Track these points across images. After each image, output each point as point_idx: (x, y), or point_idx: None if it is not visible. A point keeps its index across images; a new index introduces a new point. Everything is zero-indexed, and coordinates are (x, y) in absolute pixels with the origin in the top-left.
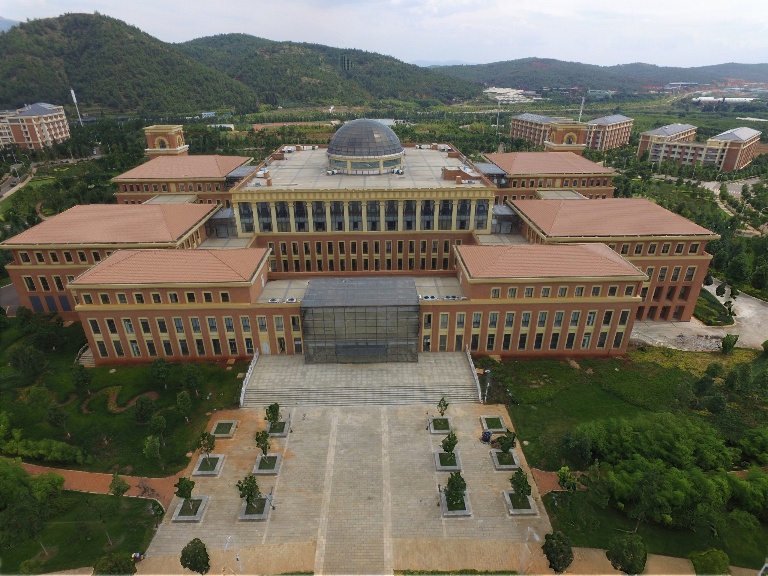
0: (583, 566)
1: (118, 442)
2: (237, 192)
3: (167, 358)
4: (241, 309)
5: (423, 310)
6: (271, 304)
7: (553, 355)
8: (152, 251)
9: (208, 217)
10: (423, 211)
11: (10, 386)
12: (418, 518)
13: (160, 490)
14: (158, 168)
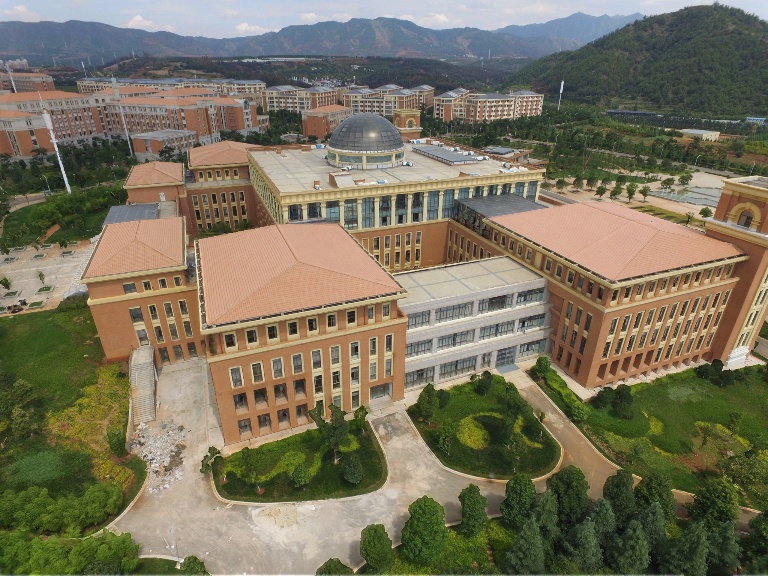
0: None
1: (73, 229)
2: None
3: None
4: None
5: None
6: None
7: None
8: (155, 162)
9: (246, 164)
10: None
11: None
12: None
13: None
14: None
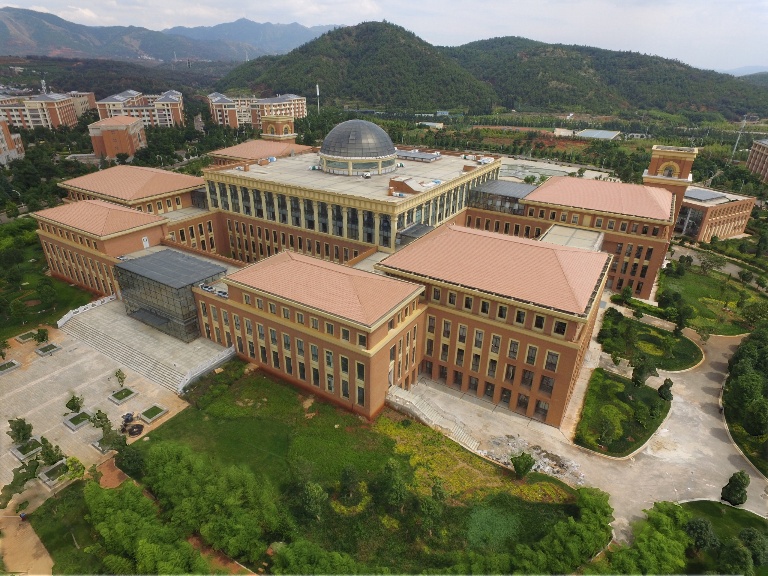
0: (8, 540)
1: None
2: (206, 171)
3: (78, 283)
4: (101, 257)
5: (198, 297)
6: (113, 259)
7: (302, 386)
8: (87, 202)
9: (191, 189)
10: (335, 216)
11: None
12: (1, 443)
13: None
14: (243, 149)
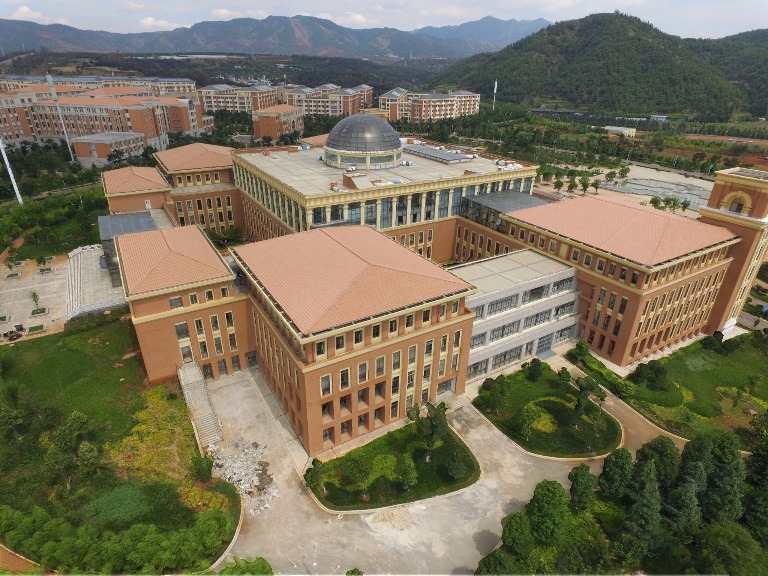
0: None
1: None
2: None
3: None
4: None
5: None
6: None
7: None
8: None
9: (228, 167)
10: None
11: (95, 215)
12: None
13: (1, 261)
14: (325, 138)
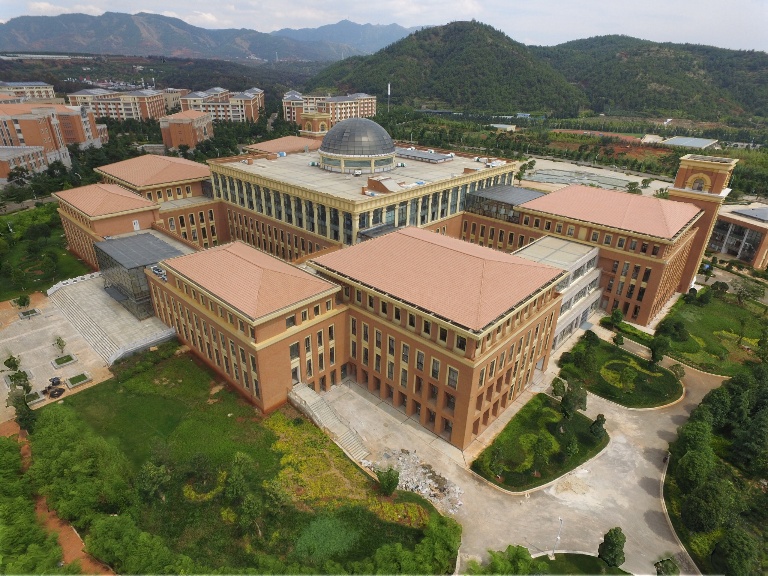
0: None
1: None
2: (211, 163)
3: None
4: None
5: (149, 279)
6: (99, 238)
7: (219, 373)
8: (96, 186)
9: (201, 179)
10: (309, 211)
11: None
12: None
13: None
14: (275, 144)
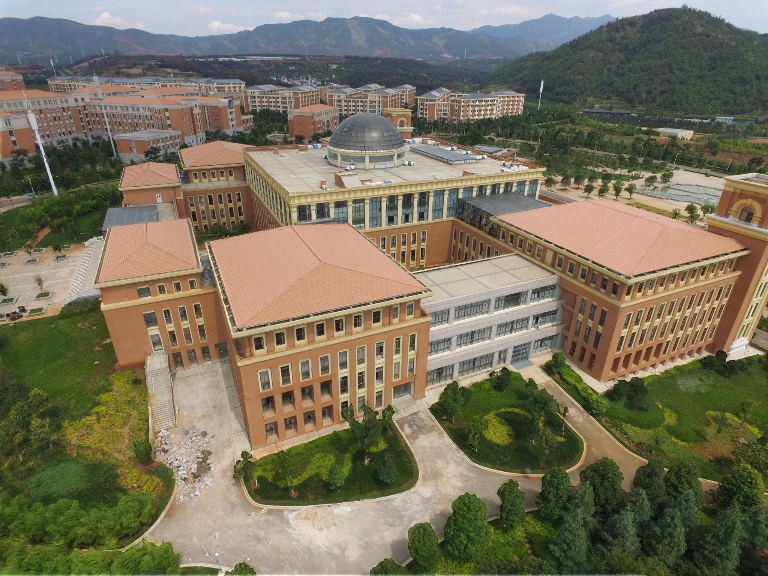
0: None
1: None
2: None
3: None
4: None
5: None
6: None
7: None
8: (149, 163)
9: (242, 164)
10: None
11: None
12: None
13: None
14: None
